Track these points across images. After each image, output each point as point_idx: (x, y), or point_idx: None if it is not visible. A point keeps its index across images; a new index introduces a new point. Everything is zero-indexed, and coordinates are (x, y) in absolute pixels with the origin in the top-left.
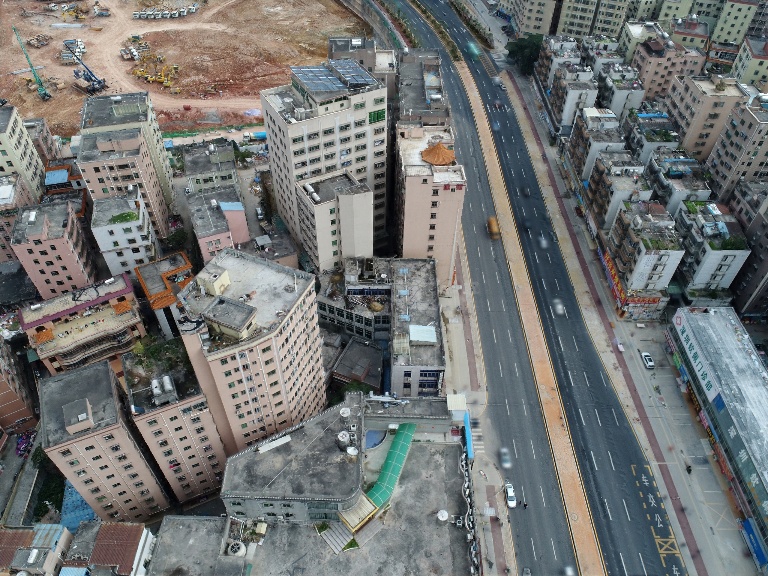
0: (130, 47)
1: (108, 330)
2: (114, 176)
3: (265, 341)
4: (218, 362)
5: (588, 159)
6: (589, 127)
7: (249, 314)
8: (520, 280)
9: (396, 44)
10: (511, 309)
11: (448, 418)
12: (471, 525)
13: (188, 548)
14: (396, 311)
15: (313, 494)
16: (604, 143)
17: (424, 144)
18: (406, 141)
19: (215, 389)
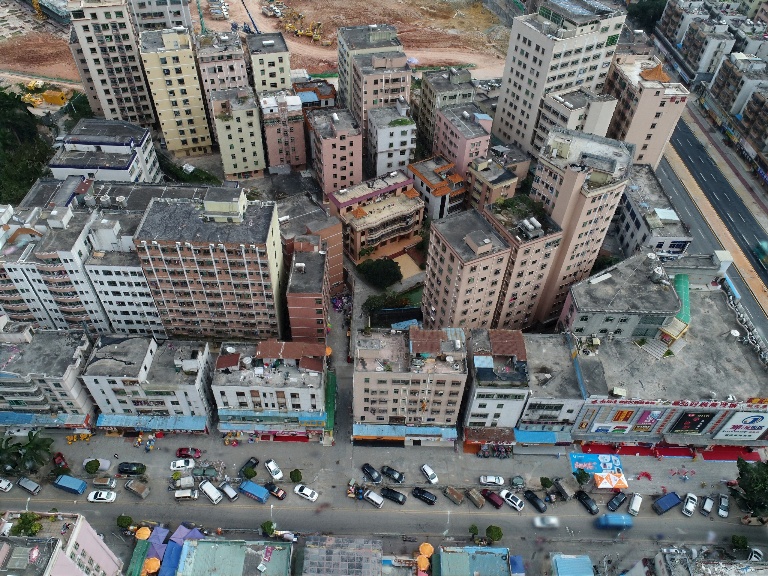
0: (271, 5)
1: (404, 211)
2: (386, 89)
3: (621, 186)
4: (591, 200)
5: (740, 95)
6: (740, 68)
7: (611, 164)
8: (696, 193)
9: (519, 6)
10: (695, 214)
11: (717, 268)
12: (755, 341)
13: (544, 355)
14: (634, 200)
15: (648, 309)
16: (757, 80)
17: (637, 68)
18: (621, 66)
19: (566, 230)
